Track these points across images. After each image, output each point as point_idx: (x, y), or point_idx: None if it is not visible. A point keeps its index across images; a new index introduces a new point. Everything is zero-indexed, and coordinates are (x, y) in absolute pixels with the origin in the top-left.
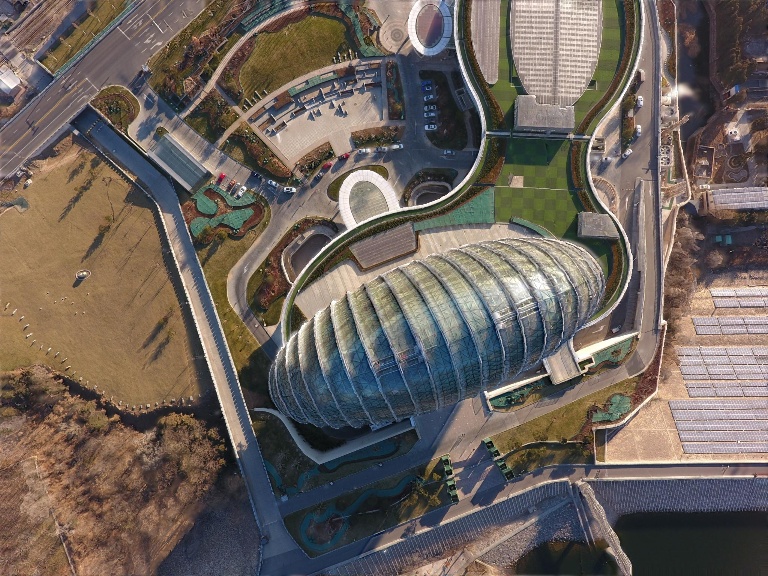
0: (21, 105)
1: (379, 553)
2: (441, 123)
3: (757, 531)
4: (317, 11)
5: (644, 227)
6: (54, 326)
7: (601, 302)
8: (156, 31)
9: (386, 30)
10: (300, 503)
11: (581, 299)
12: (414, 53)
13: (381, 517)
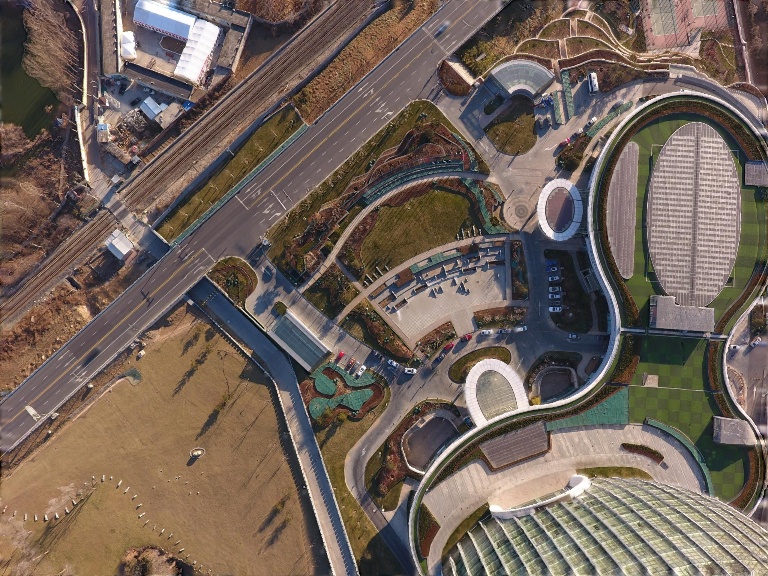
0: (132, 269)
1: None
2: (568, 307)
3: None
4: (441, 185)
5: None
6: (167, 506)
7: None
8: (275, 201)
9: (510, 206)
10: None
11: None
12: (539, 230)
13: None
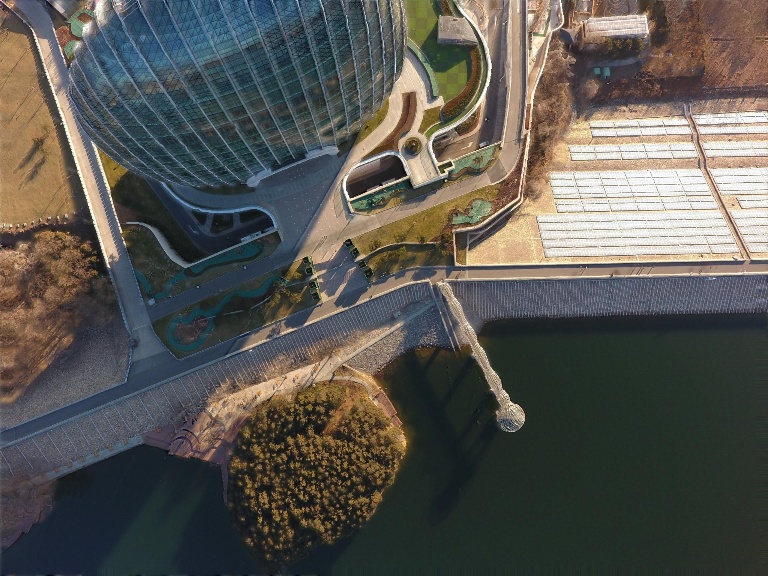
0: None
1: (245, 355)
2: None
3: (618, 335)
4: None
5: (510, 42)
6: None
7: (460, 106)
8: None
9: None
10: (168, 308)
11: None
12: None
13: (244, 316)
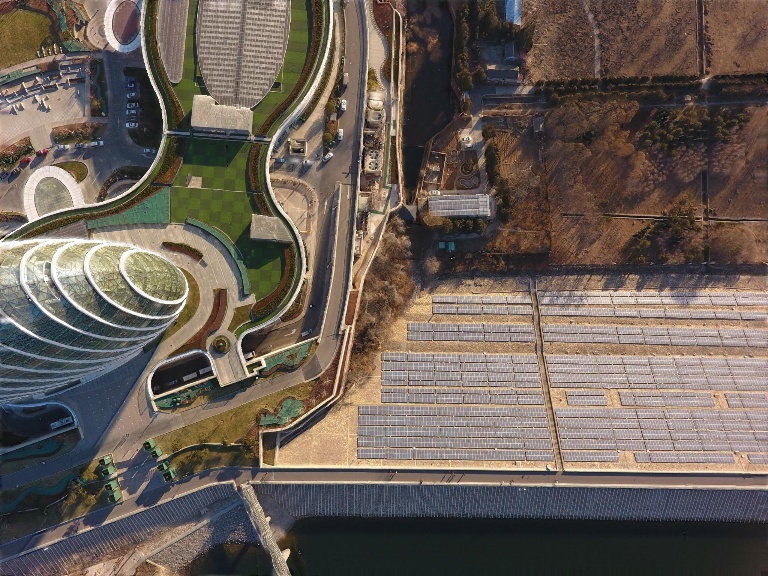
0: None
1: (42, 551)
2: (139, 121)
3: (431, 537)
4: (23, 4)
5: (336, 231)
6: None
7: (271, 305)
8: None
9: (94, 25)
10: None
11: (10, 302)
12: None
13: (38, 515)
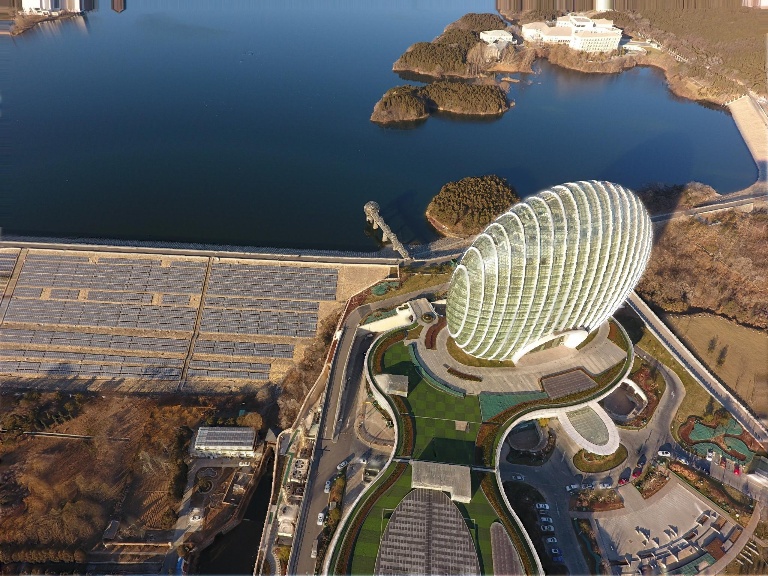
0: None
1: None
2: None
3: (299, 242)
4: None
5: None
6: None
7: (392, 338)
8: None
9: None
10: None
11: None
12: None
13: None
